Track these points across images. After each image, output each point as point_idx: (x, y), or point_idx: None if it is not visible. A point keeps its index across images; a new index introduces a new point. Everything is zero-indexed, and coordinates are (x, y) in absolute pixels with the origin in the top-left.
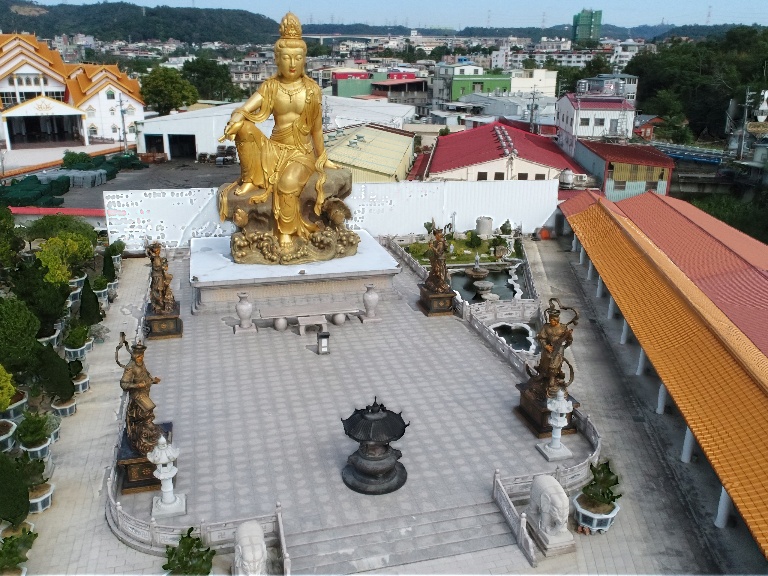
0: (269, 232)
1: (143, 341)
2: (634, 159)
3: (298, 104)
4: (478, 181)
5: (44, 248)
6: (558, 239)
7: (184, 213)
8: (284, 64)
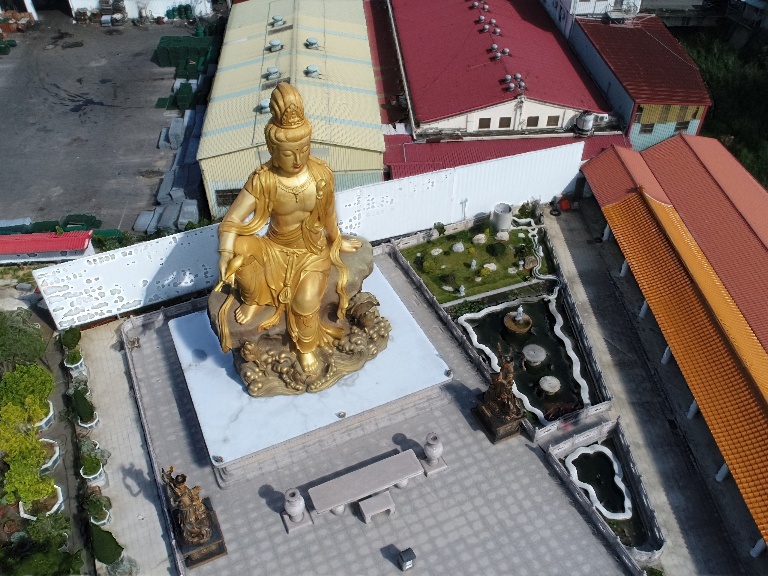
0: (284, 348)
1: (184, 574)
2: (662, 88)
3: (307, 203)
4: (493, 160)
5: (2, 433)
6: (580, 209)
7: (143, 270)
8: (285, 161)
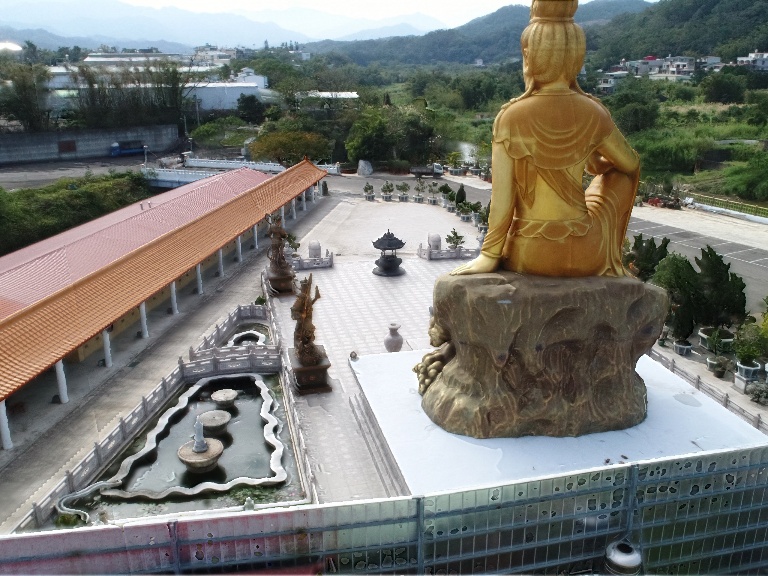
0: None
1: None
2: None
3: None
4: None
5: None
6: None
7: None
8: None
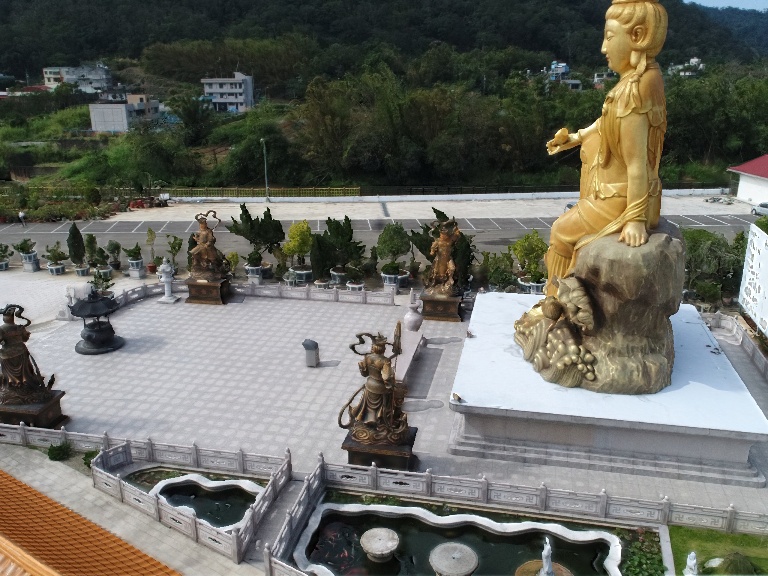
0: None
1: (422, 307)
2: None
3: None
4: None
5: None
6: None
7: None
8: None
